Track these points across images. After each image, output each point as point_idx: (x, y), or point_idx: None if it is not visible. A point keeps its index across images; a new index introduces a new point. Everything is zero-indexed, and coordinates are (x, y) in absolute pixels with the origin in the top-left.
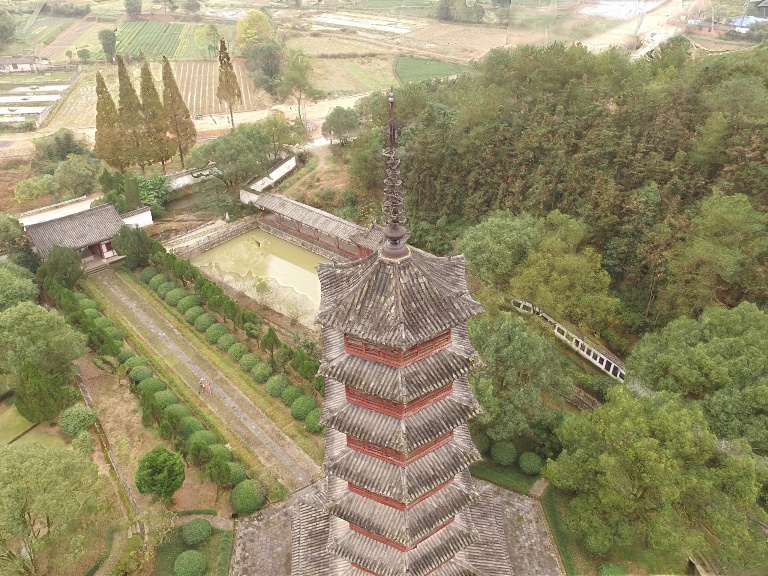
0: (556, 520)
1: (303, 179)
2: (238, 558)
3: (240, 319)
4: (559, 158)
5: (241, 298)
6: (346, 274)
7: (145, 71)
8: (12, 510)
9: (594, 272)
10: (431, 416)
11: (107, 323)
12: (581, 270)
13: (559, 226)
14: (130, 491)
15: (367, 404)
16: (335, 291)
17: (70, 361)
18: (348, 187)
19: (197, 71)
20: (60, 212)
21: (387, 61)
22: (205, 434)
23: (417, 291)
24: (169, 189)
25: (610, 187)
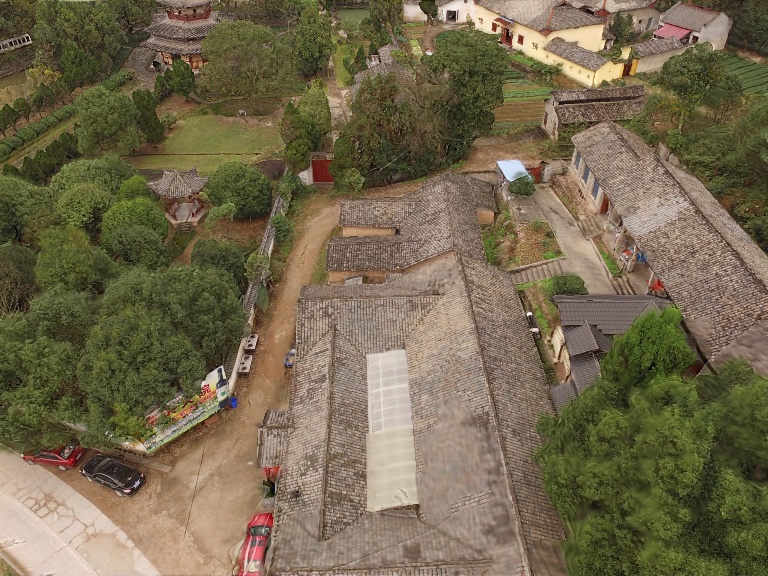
0: None
1: None
2: None
3: None
4: None
5: None
6: None
7: None
8: None
9: None
10: None
11: None
12: None
13: None
14: None
15: None
16: None
17: None
18: None
19: None
20: None
21: None
22: None
23: None
24: None
25: None
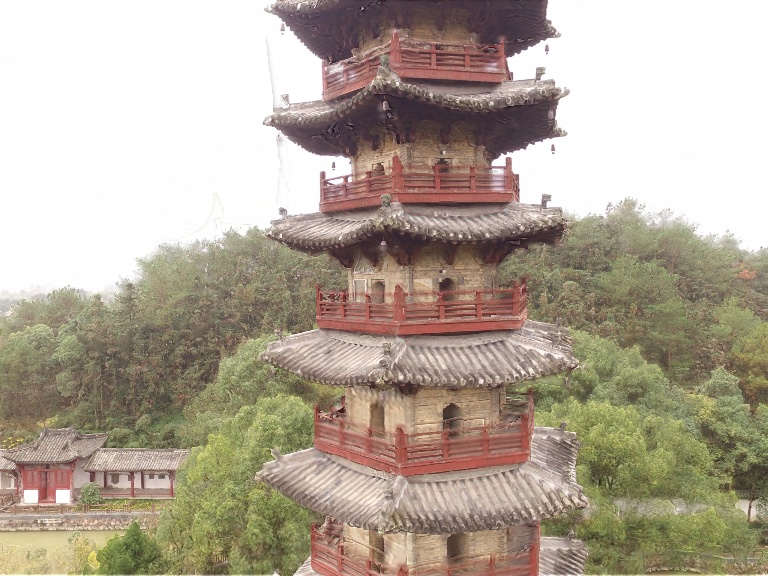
0: None
1: None
2: None
3: None
4: (286, 300)
5: None
6: None
7: None
8: None
9: None
10: None
11: None
12: None
13: None
14: None
15: (442, 191)
16: None
17: None
18: None
19: None
20: None
21: None
22: None
23: None
24: None
25: None
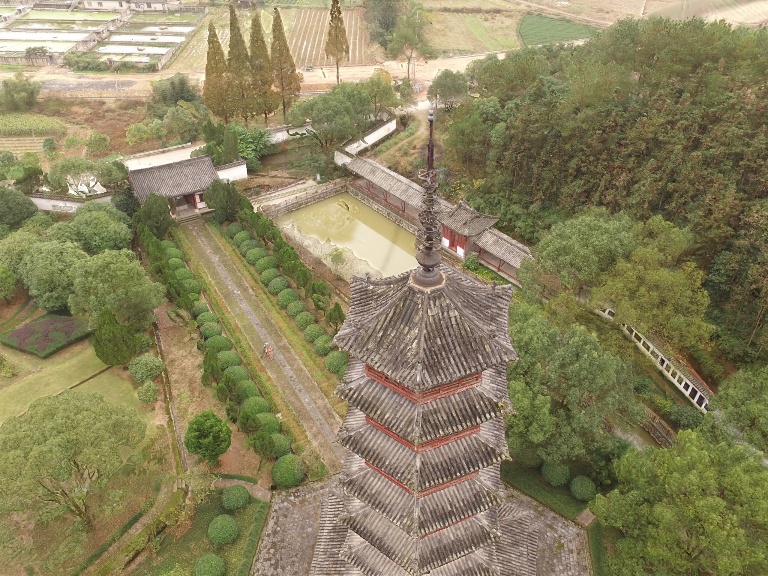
0: (600, 556)
1: (400, 144)
2: (269, 531)
3: (310, 289)
4: (674, 154)
5: (317, 265)
6: (377, 292)
7: (256, 22)
8: (60, 459)
9: (691, 291)
10: (452, 453)
11: (188, 275)
12: (675, 288)
13: (659, 234)
14: (183, 445)
15: (385, 430)
16: (362, 310)
17: (147, 310)
18: (443, 158)
19: (316, 19)
20: (166, 157)
21: (512, 19)
22: (258, 401)
23: (446, 325)
24: (268, 143)
25: (729, 194)
